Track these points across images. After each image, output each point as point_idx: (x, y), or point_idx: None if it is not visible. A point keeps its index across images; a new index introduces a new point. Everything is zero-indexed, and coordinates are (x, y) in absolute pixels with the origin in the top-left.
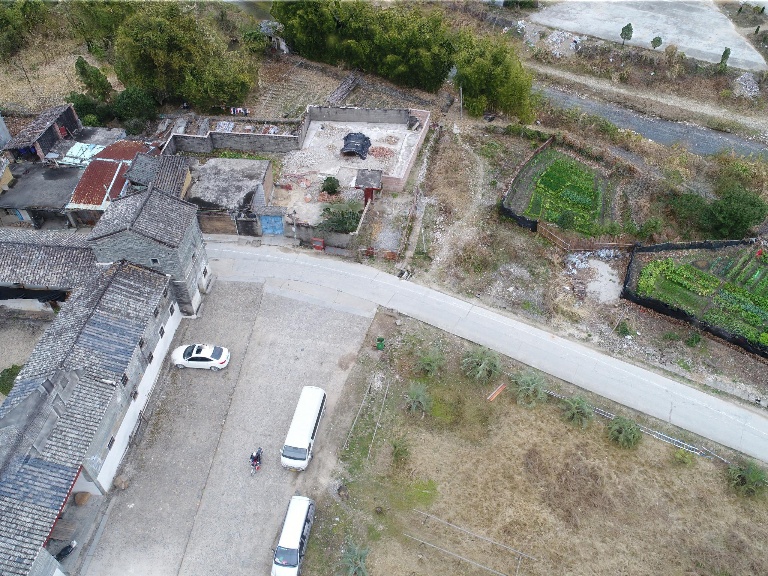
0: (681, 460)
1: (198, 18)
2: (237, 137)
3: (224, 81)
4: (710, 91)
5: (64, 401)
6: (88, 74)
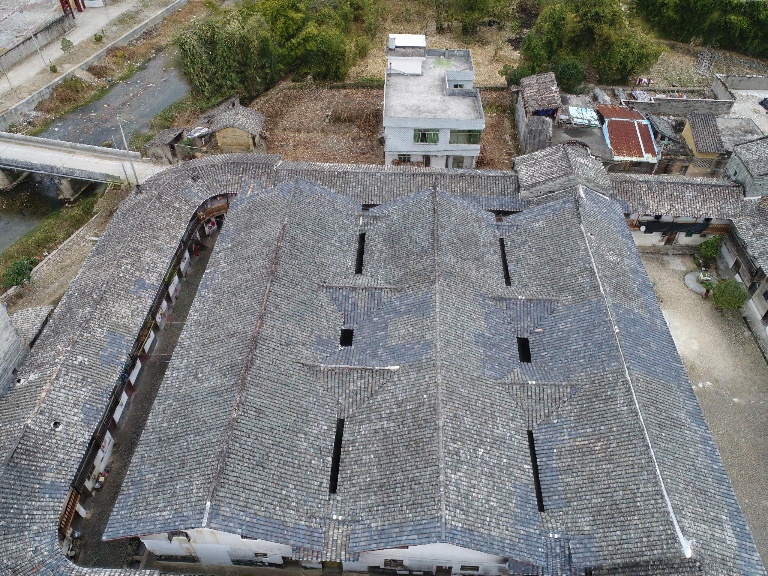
0: None
1: None
2: (675, 102)
3: (650, 53)
4: None
5: (764, 312)
6: (531, 48)
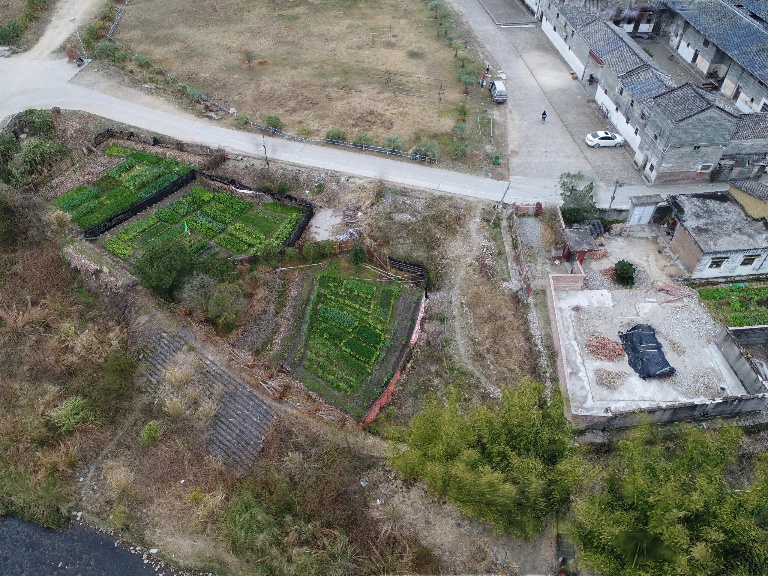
0: None
1: None
2: None
3: None
4: None
5: None
6: None
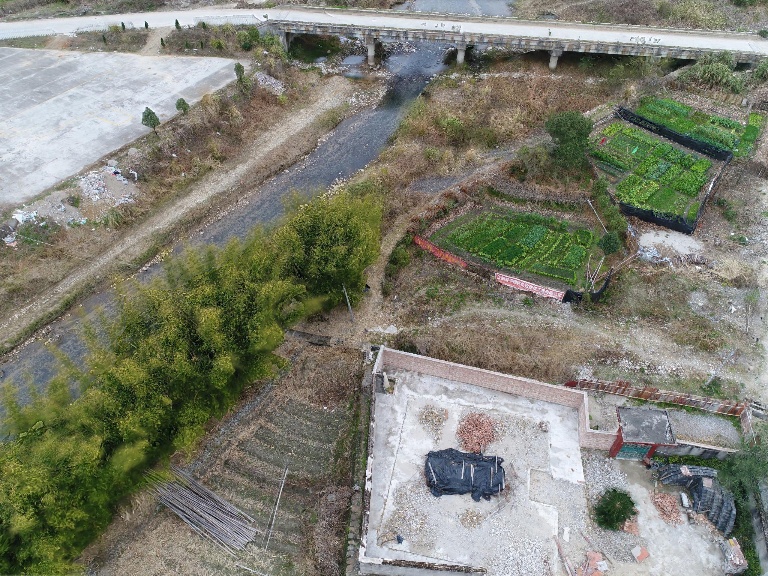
0: None
1: None
2: None
3: None
4: (269, 107)
5: None
6: None
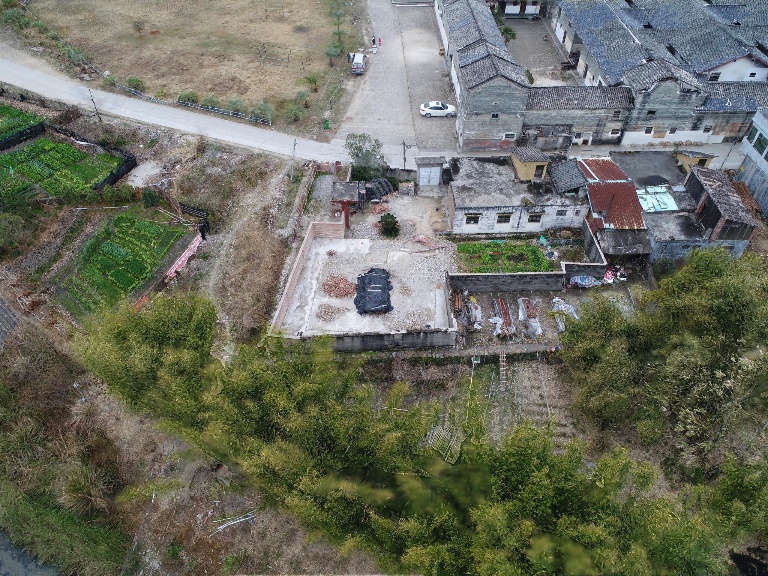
0: None
1: (762, 421)
2: (528, 277)
3: None
4: None
5: None
6: None
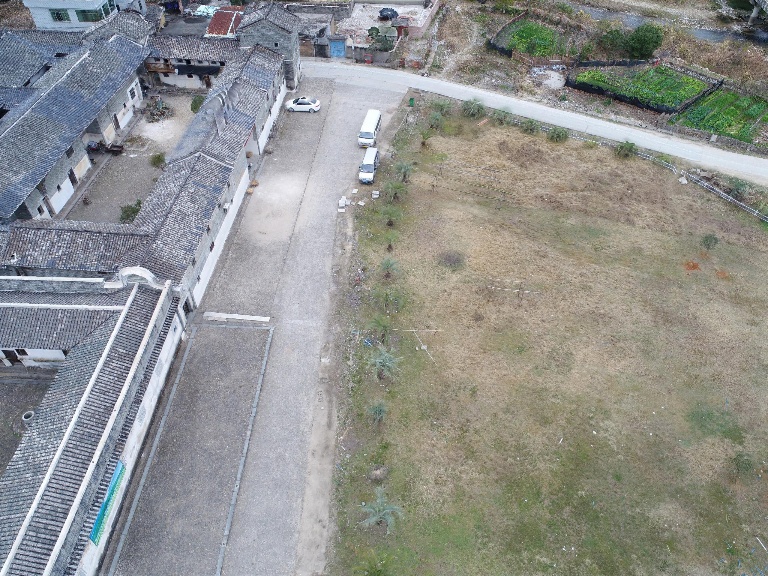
0: (589, 145)
1: None
2: (306, 9)
3: None
4: None
5: None
6: None
